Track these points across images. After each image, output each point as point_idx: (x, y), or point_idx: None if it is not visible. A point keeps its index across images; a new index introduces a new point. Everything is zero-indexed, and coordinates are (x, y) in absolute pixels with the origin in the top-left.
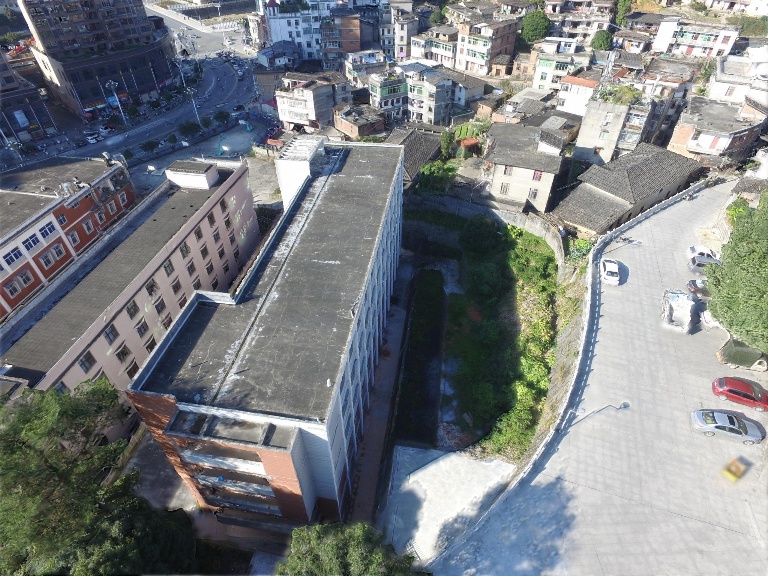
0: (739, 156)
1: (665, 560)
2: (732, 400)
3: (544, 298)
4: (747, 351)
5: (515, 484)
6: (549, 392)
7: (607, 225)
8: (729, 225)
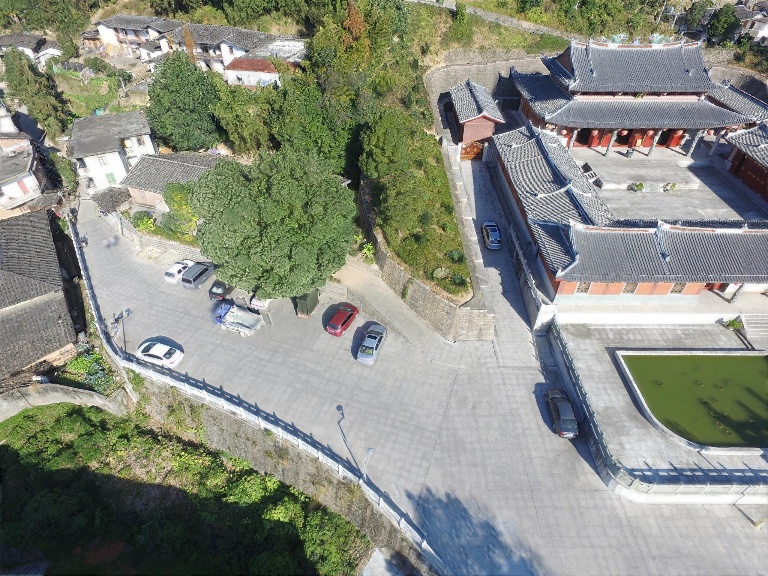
0: (49, 184)
1: (484, 436)
2: (346, 328)
3: (143, 442)
4: (312, 296)
5: (436, 555)
6: (286, 481)
7: (70, 328)
8: (155, 236)
